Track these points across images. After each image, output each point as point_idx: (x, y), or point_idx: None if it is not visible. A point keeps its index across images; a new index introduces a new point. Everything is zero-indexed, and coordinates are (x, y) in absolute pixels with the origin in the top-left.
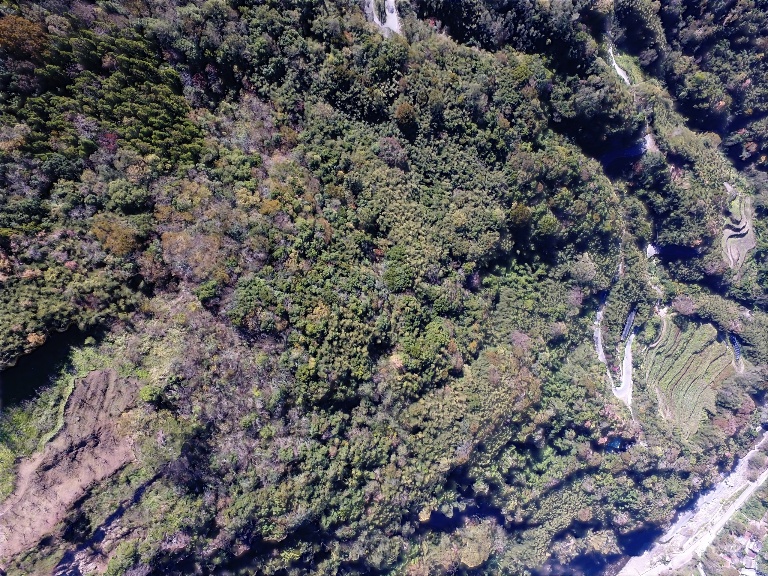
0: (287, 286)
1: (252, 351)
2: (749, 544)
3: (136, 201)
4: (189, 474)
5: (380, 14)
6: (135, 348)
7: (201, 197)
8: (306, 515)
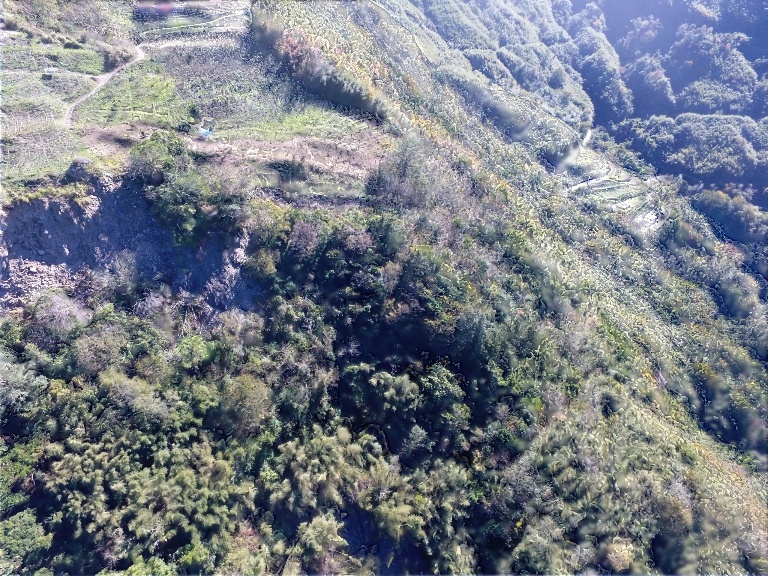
0: None
1: (482, 198)
2: None
3: None
4: None
5: None
6: None
7: None
8: (489, 312)
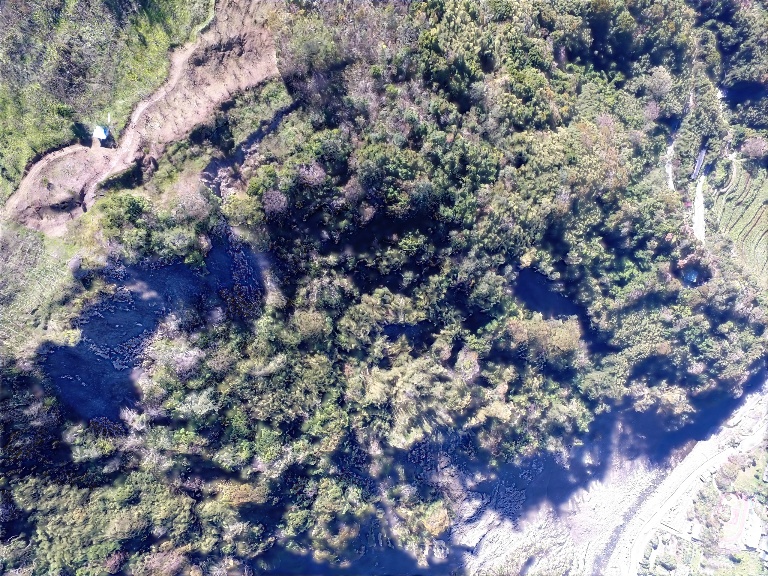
0: None
1: None
2: None
3: None
4: None
5: None
6: None
7: None
8: (429, 186)
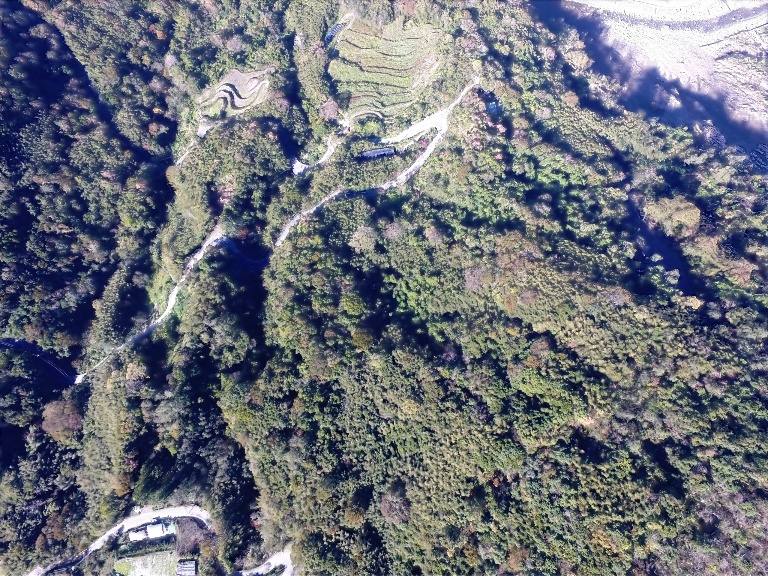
0: None
1: None
2: None
3: None
4: None
5: (278, 574)
6: None
7: None
8: None
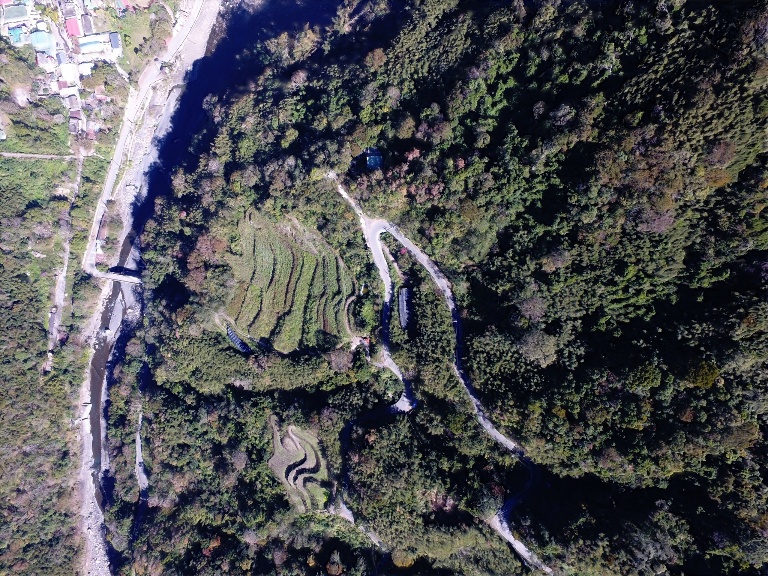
0: None
1: None
2: (83, 125)
3: None
4: None
5: None
6: None
7: None
8: None
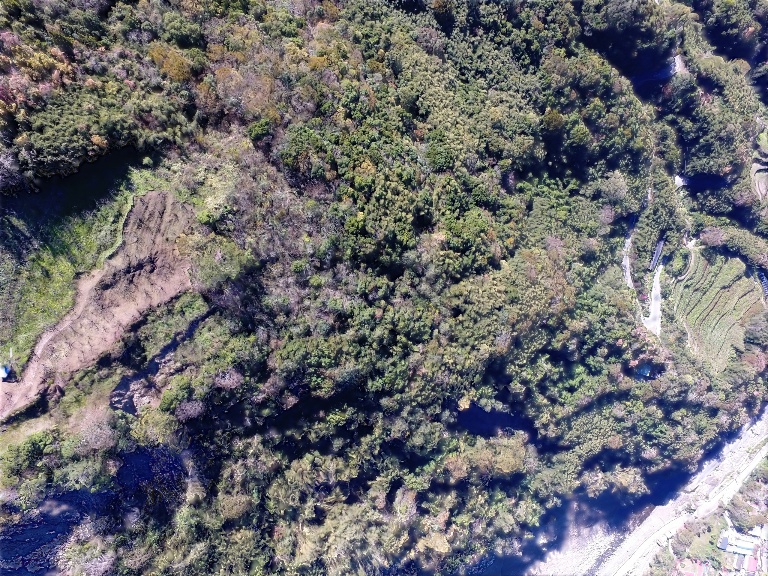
0: (336, 137)
1: (302, 198)
2: None
3: (190, 37)
4: (241, 314)
5: None
6: (191, 176)
7: (252, 40)
8: (354, 371)
